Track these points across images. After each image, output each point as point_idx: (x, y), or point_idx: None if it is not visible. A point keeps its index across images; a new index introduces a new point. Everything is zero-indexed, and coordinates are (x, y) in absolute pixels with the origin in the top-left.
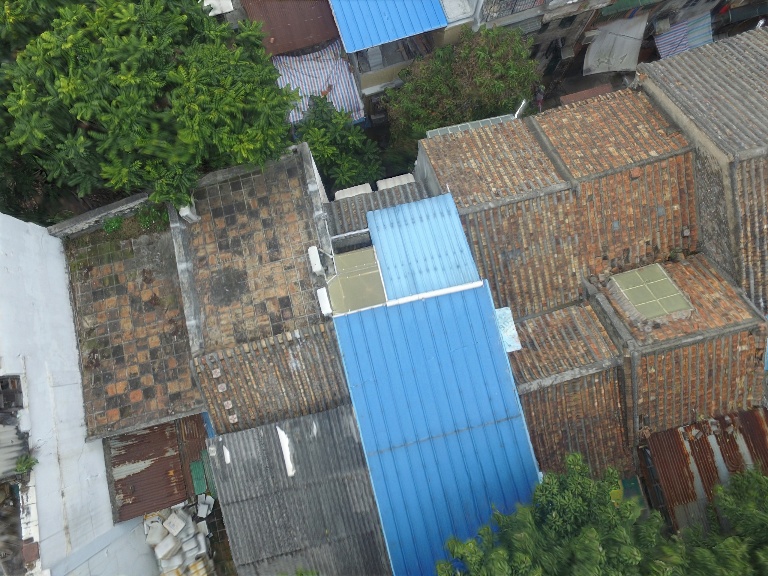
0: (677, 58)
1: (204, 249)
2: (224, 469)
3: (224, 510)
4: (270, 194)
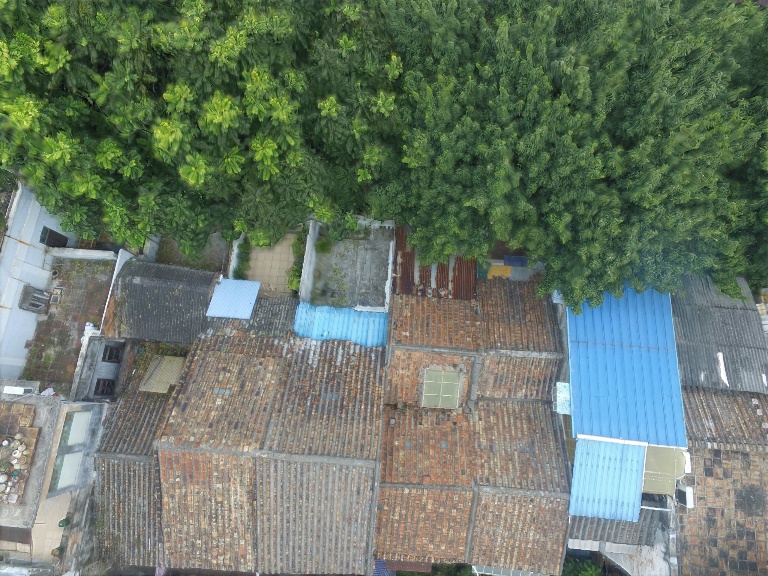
0: (339, 570)
1: (767, 538)
2: (767, 371)
3: (766, 346)
4: (708, 568)
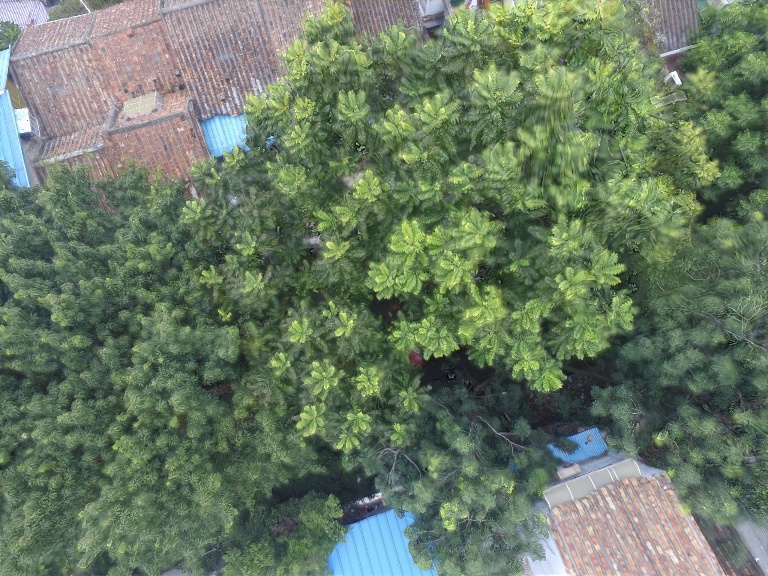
0: None
1: None
2: None
3: None
4: None
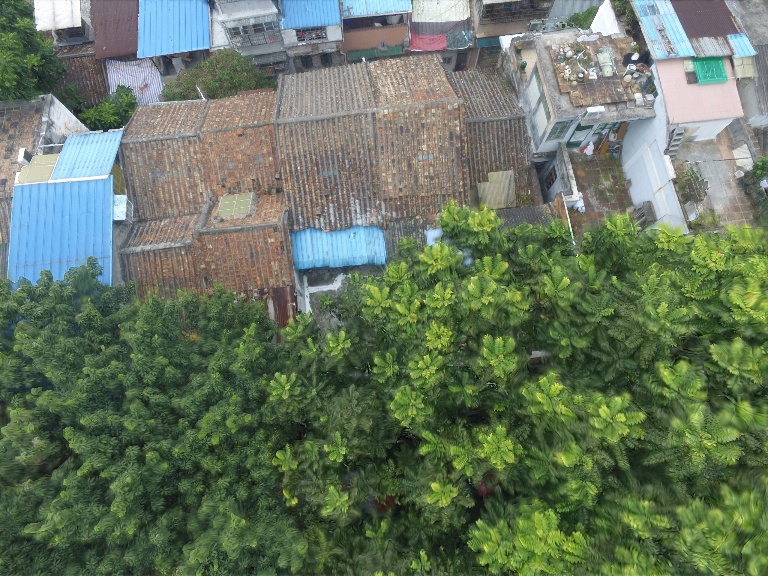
0: (304, 73)
1: None
2: None
3: None
4: (20, 121)
